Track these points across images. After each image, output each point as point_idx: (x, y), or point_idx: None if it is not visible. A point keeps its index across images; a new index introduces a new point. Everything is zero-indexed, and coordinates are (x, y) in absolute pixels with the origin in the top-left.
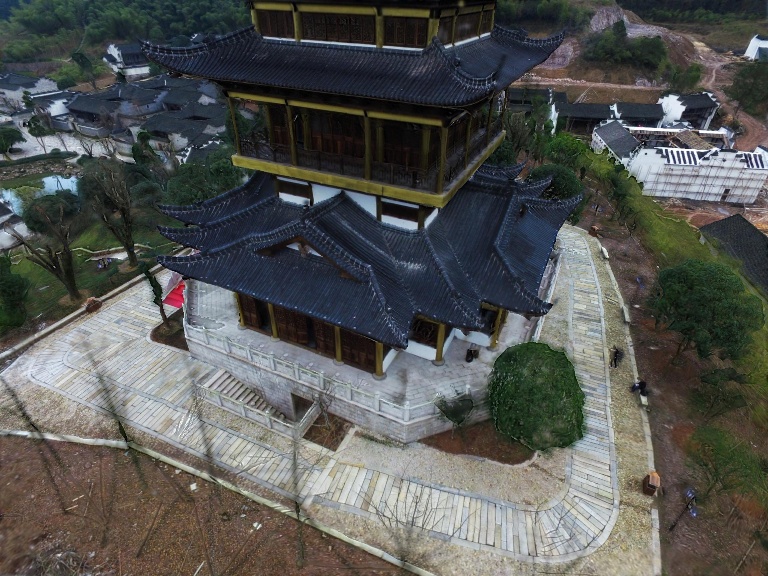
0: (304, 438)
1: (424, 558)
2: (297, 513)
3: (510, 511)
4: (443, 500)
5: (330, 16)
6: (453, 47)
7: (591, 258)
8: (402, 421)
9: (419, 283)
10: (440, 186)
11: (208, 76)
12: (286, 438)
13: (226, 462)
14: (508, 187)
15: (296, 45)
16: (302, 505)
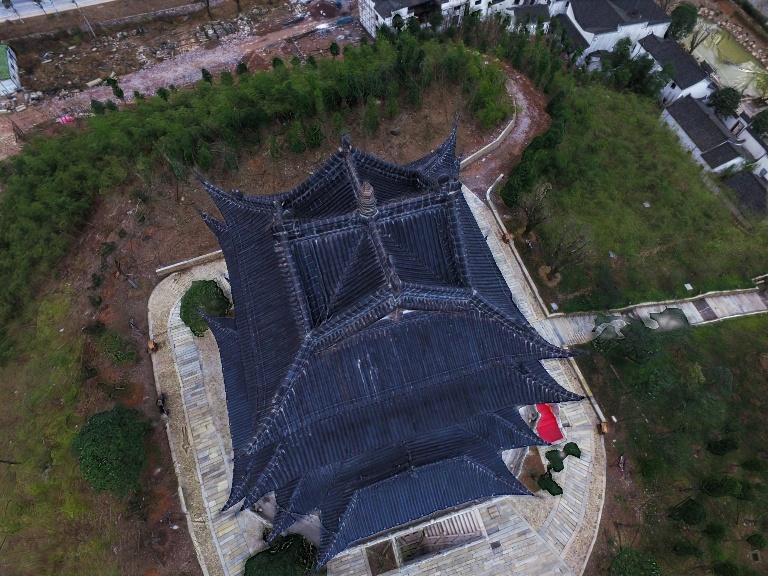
0: None
1: None
2: None
3: None
4: None
5: None
6: None
7: None
8: None
9: None
10: None
11: None
12: None
13: None
14: None
15: None
16: None
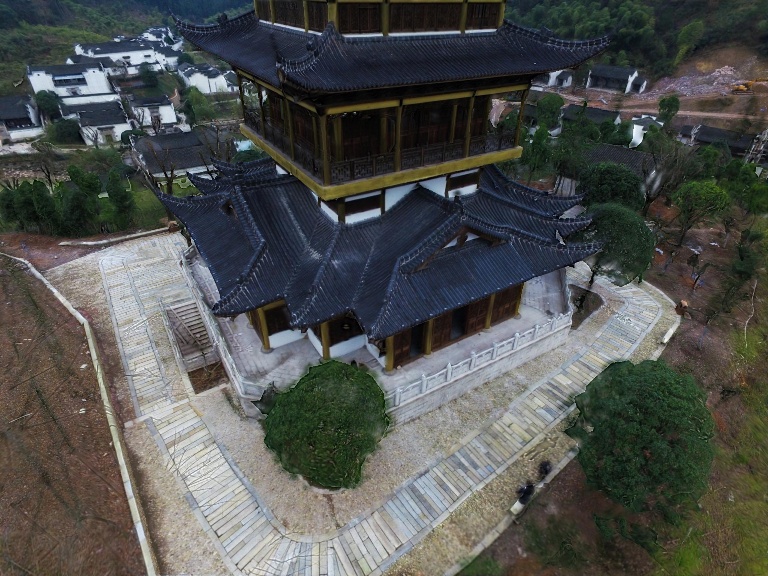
0: (188, 373)
1: (163, 508)
2: (41, 398)
3: (263, 520)
4: (224, 476)
5: (285, 1)
6: (384, 37)
7: (643, 336)
8: (241, 392)
9: (307, 272)
10: (325, 177)
11: (205, 50)
12: (177, 367)
13: (129, 364)
14: (454, 204)
15: (271, 28)
16: (136, 419)
